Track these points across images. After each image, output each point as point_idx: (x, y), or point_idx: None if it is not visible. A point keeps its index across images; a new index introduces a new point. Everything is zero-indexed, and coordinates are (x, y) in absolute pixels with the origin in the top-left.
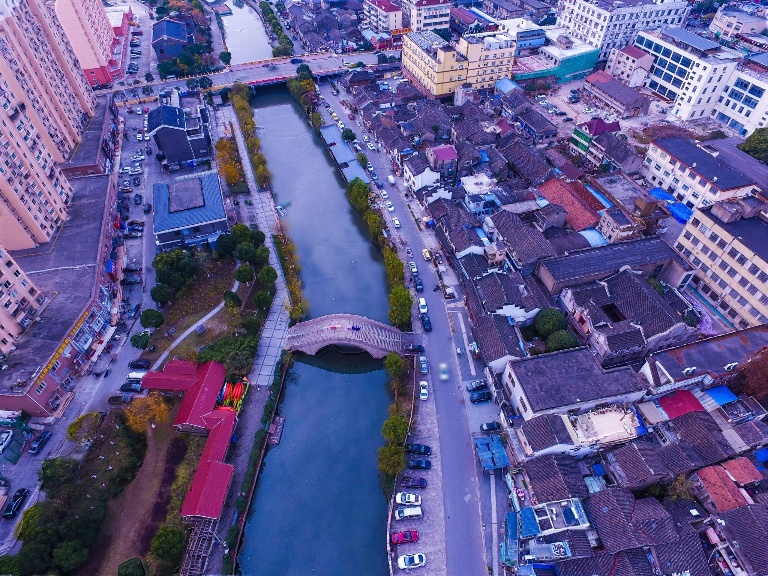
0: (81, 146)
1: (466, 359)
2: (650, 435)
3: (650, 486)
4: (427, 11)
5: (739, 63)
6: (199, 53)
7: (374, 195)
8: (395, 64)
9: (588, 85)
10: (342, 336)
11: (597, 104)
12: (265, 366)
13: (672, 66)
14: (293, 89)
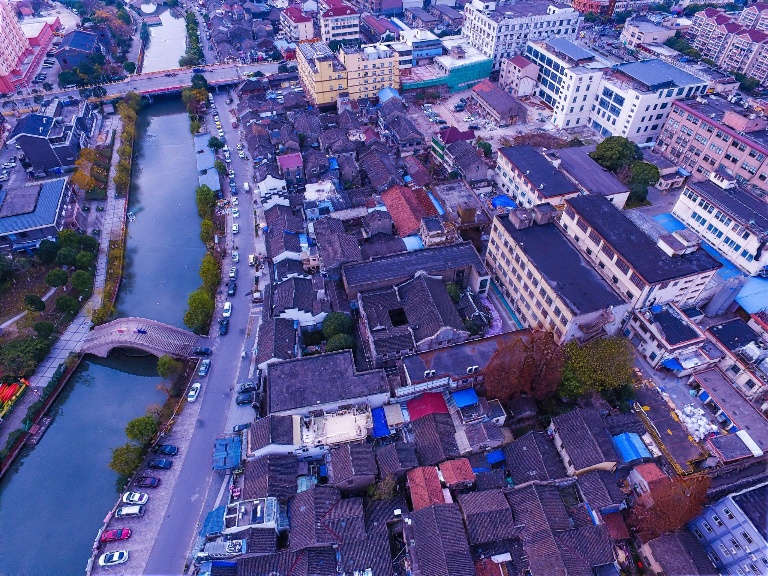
0: None
1: (249, 362)
2: (395, 437)
3: (367, 486)
4: (334, 22)
5: (606, 73)
6: (102, 63)
7: (225, 202)
8: (294, 73)
9: (474, 94)
10: (123, 339)
11: (479, 113)
12: (51, 368)
13: (554, 75)
14: (184, 98)
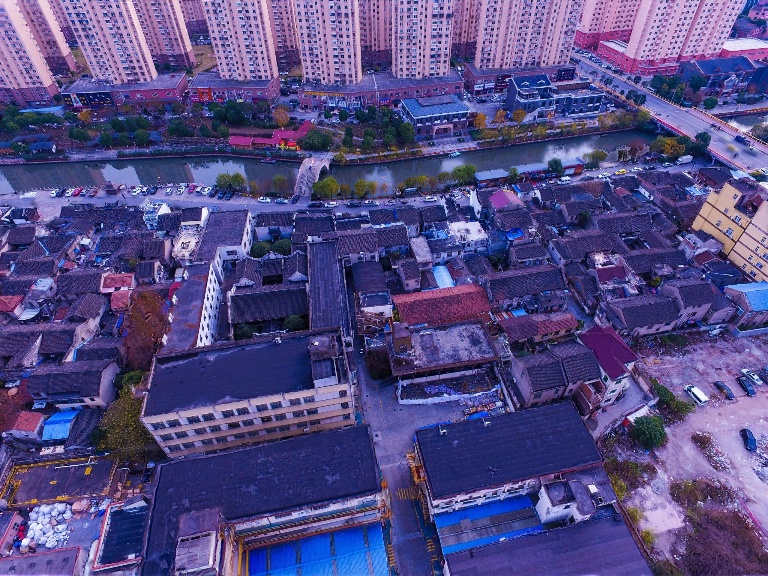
0: (499, 70)
1: None
2: None
3: None
4: None
5: None
6: (697, 86)
7: None
8: None
9: None
10: None
11: None
12: None
13: None
14: None
